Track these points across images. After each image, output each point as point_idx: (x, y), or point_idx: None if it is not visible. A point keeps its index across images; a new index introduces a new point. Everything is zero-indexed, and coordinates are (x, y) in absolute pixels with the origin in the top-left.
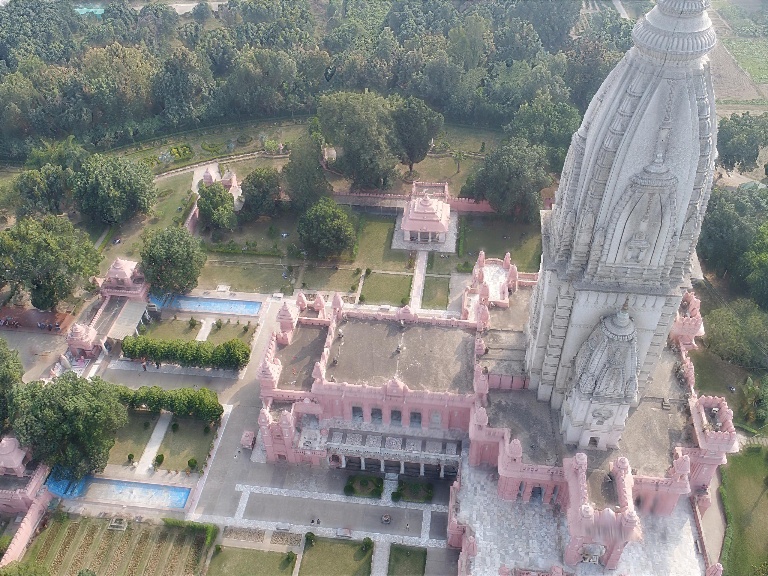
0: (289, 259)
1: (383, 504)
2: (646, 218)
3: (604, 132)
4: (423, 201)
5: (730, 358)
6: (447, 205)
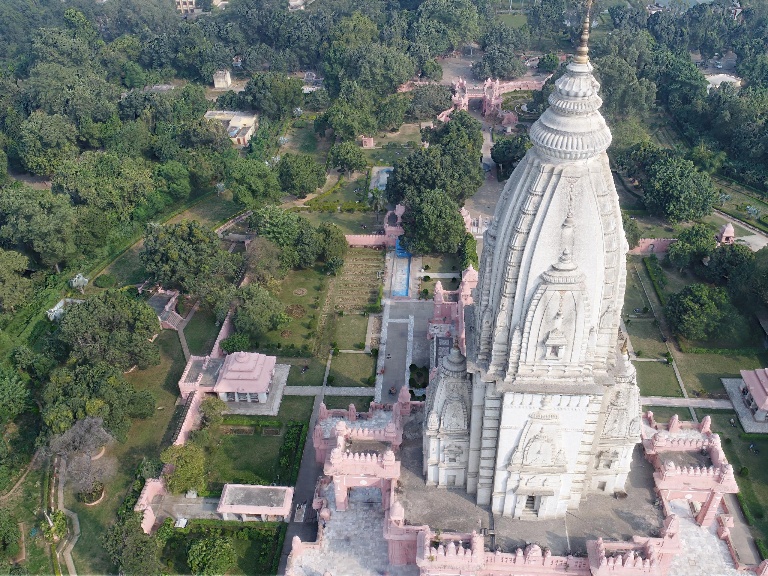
0: (662, 309)
1: None
2: None
3: None
4: None
5: None
6: None
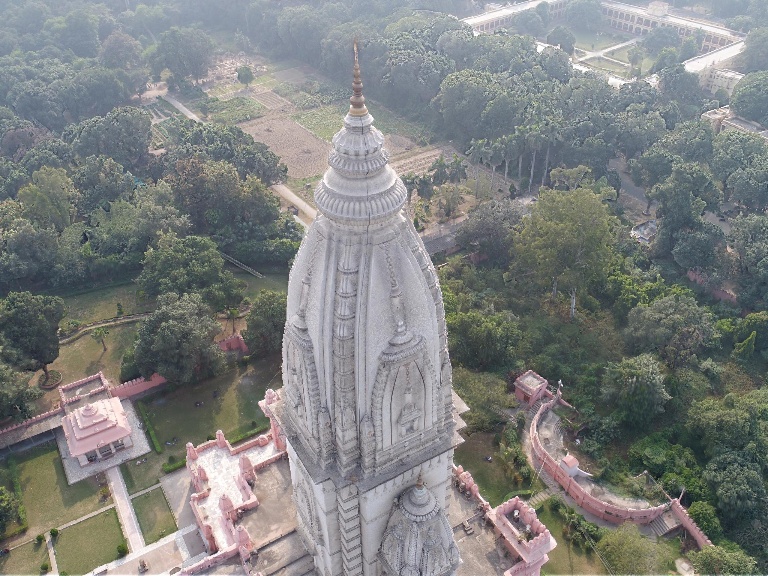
0: None
1: None
2: (409, 389)
3: (330, 320)
4: (85, 412)
5: (474, 431)
6: (115, 400)
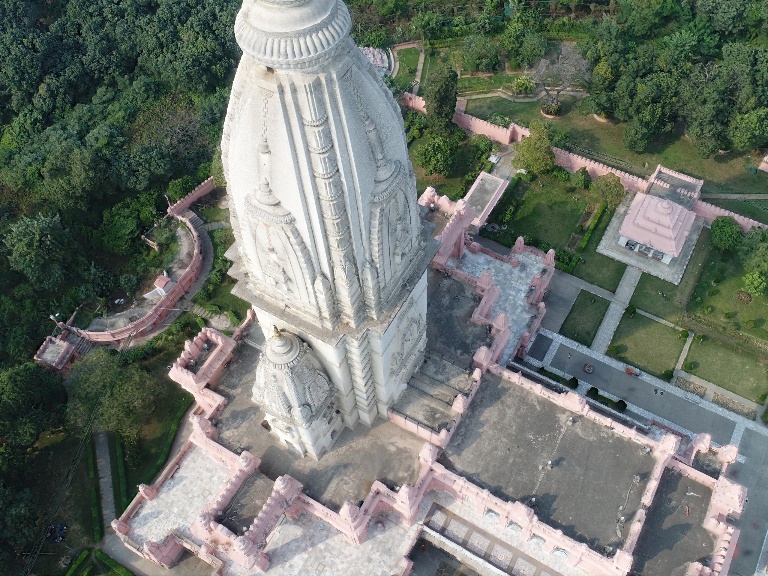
0: None
1: (588, 385)
2: None
3: (394, 113)
4: None
5: None
6: None
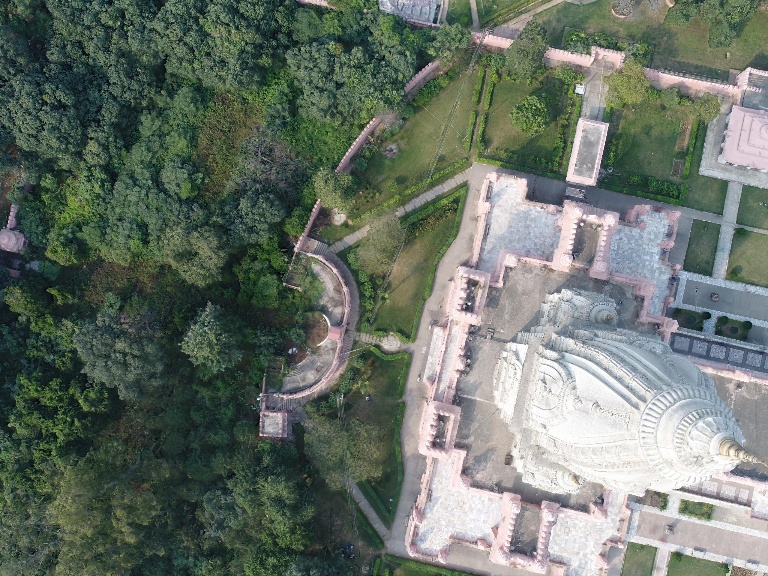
0: None
1: (717, 312)
2: None
3: None
4: None
5: None
6: None
